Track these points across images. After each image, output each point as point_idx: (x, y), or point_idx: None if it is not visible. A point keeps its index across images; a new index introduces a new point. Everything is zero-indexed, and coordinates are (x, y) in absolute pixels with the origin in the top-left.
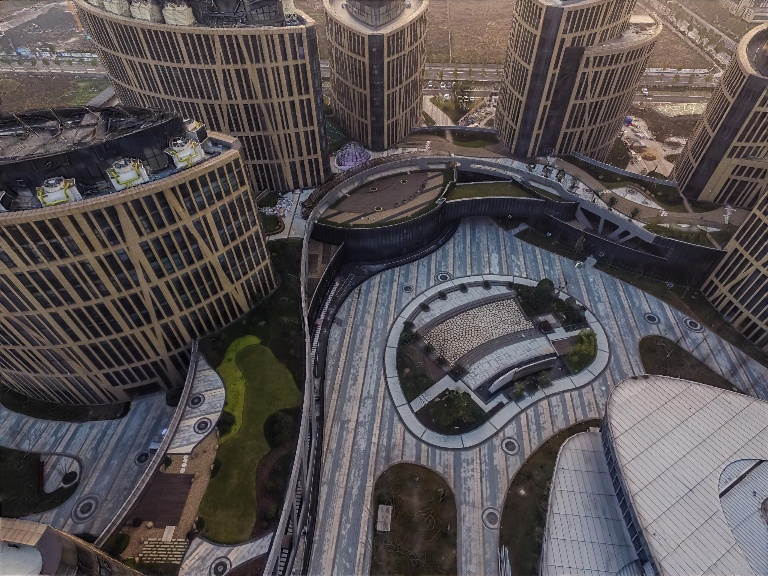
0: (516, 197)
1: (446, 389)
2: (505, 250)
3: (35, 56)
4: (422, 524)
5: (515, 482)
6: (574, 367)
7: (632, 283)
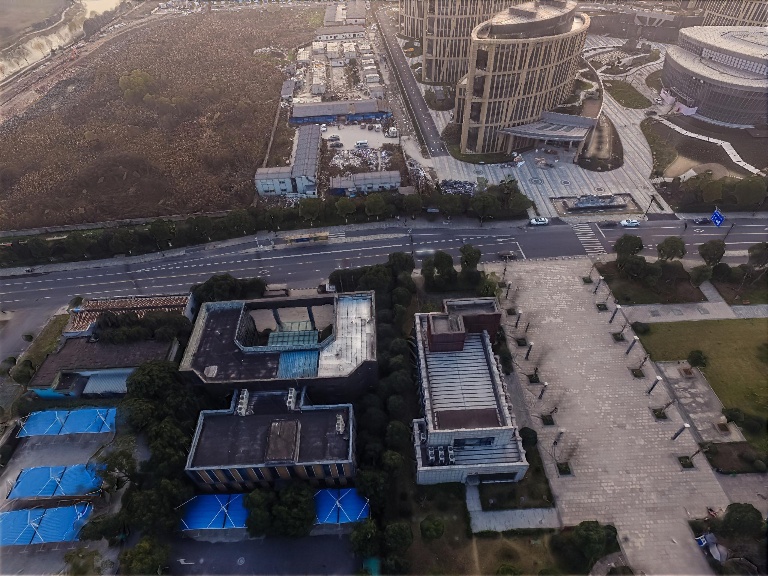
0: (607, 15)
1: (608, 67)
2: (604, 40)
3: (249, 2)
4: (622, 85)
5: (647, 79)
6: (653, 60)
7: (665, 43)
